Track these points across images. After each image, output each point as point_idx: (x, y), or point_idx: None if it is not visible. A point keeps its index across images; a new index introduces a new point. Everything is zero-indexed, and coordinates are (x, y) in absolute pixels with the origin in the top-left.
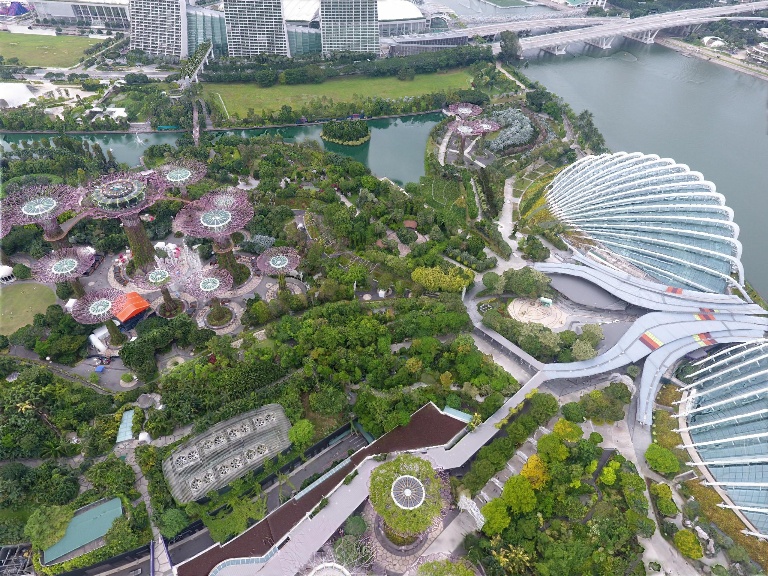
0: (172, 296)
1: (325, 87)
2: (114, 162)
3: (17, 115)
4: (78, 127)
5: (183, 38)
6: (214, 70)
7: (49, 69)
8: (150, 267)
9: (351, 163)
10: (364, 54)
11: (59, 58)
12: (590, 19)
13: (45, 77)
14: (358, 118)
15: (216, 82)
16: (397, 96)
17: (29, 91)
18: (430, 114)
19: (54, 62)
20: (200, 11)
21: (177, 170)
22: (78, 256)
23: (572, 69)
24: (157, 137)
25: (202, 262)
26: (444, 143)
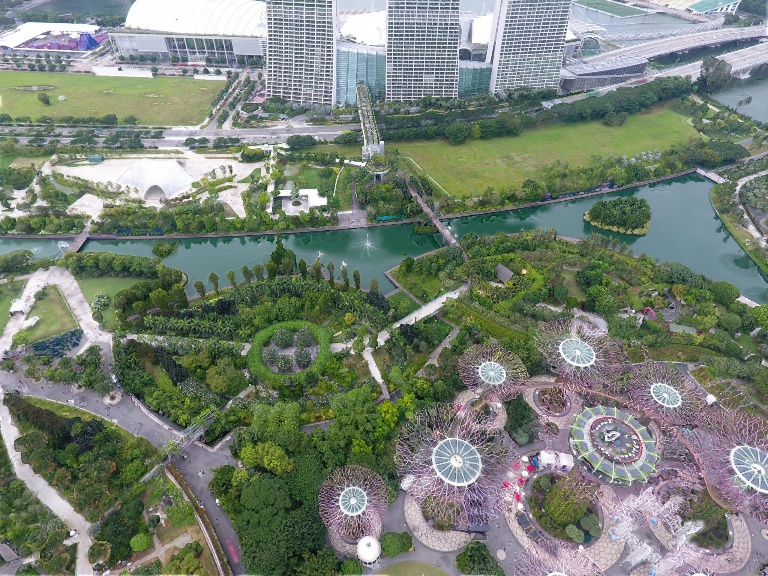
0: (645, 575)
1: (528, 141)
2: (378, 293)
3: (189, 211)
4: (275, 225)
5: (333, 82)
6: (388, 124)
7: (176, 129)
8: (591, 522)
9: (718, 284)
10: (543, 91)
11: (177, 111)
12: (739, 30)
13: (185, 144)
14: (607, 188)
15: (395, 140)
16: (625, 151)
17: (184, 171)
18: (682, 176)
19: (175, 117)
20: (353, 47)
21: (567, 342)
22: (561, 561)
23: (757, 95)
24: (382, 234)
25: (633, 490)
26: (750, 225)
